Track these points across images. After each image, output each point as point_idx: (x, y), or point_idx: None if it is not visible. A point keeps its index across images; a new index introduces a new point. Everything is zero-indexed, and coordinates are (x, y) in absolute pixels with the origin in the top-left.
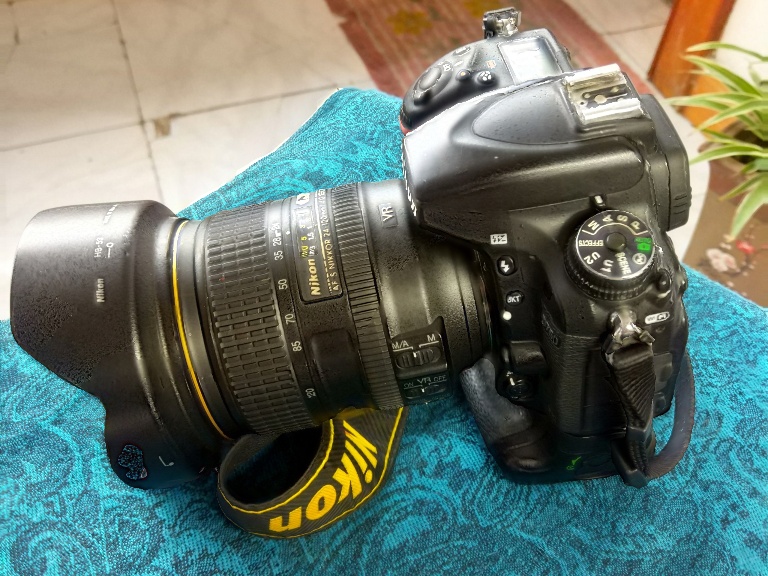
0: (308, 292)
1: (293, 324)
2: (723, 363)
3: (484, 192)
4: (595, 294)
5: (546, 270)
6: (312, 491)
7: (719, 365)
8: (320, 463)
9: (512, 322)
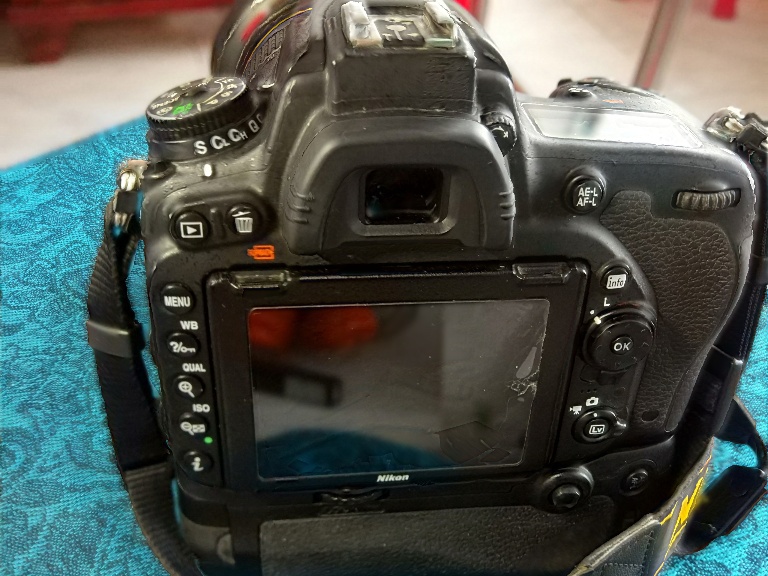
0: None
1: None
2: None
3: None
4: None
5: None
6: None
7: None
8: None
9: None
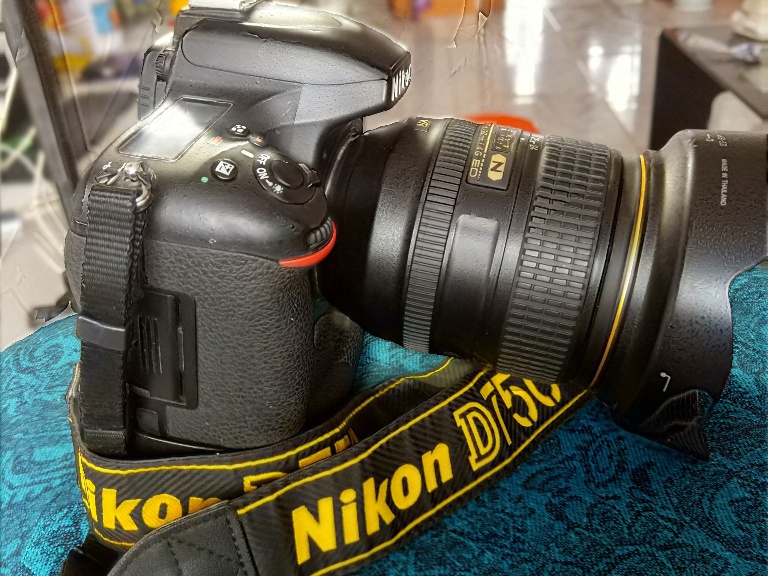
0: None
1: None
2: None
3: None
4: None
5: None
6: None
7: None
8: None
9: None
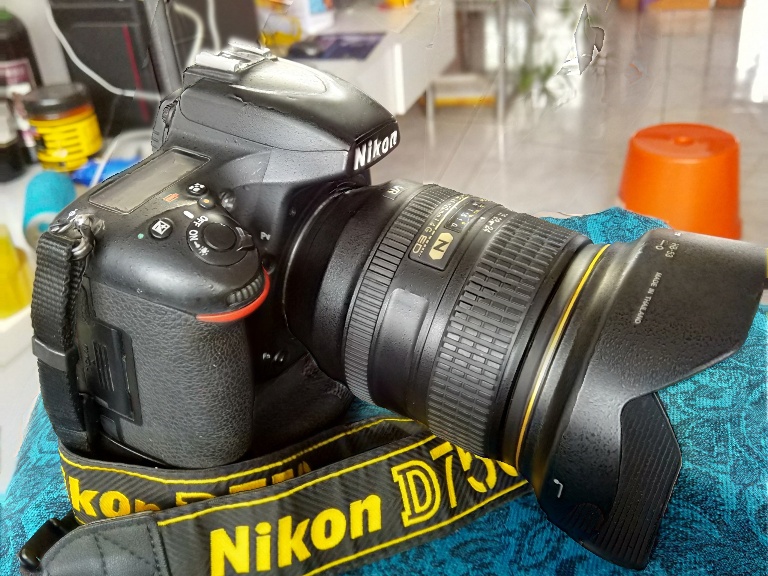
0: None
1: None
2: None
3: None
4: None
5: None
6: None
7: None
8: None
9: None
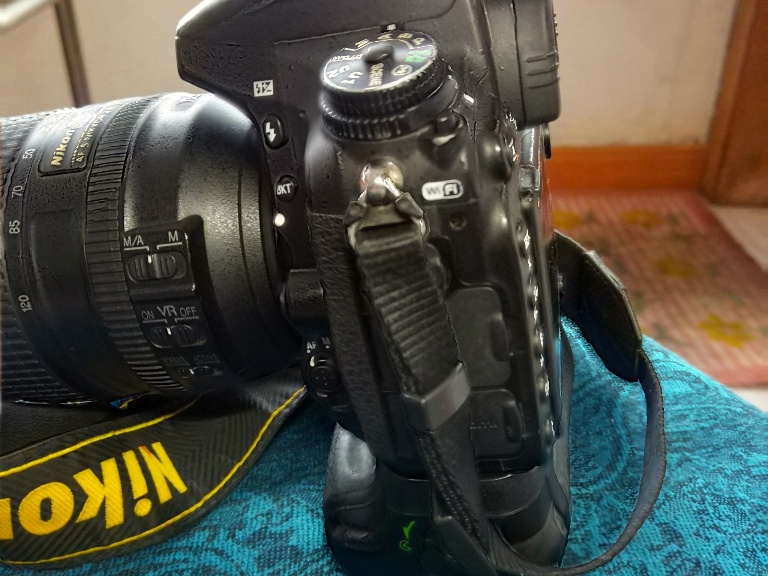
0: (48, 162)
1: (18, 198)
2: (746, 505)
3: (246, 15)
4: (341, 131)
5: (310, 126)
6: (32, 480)
7: (739, 506)
8: (60, 448)
9: (287, 232)
